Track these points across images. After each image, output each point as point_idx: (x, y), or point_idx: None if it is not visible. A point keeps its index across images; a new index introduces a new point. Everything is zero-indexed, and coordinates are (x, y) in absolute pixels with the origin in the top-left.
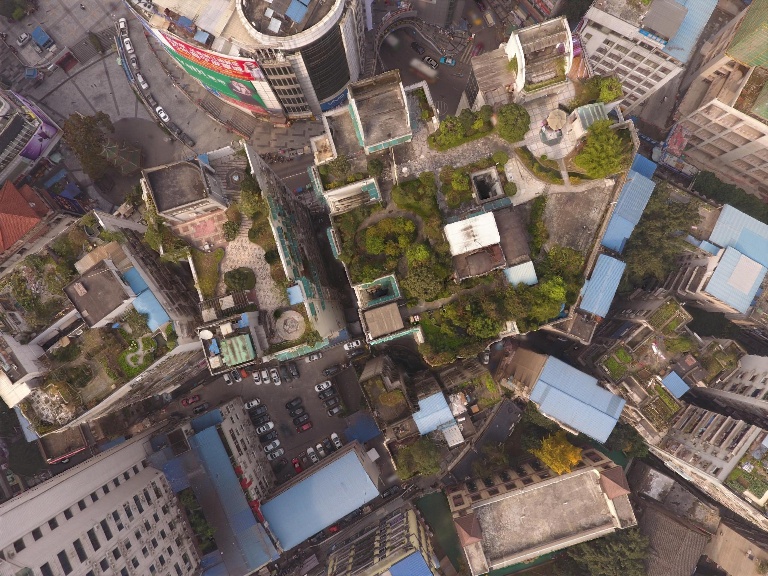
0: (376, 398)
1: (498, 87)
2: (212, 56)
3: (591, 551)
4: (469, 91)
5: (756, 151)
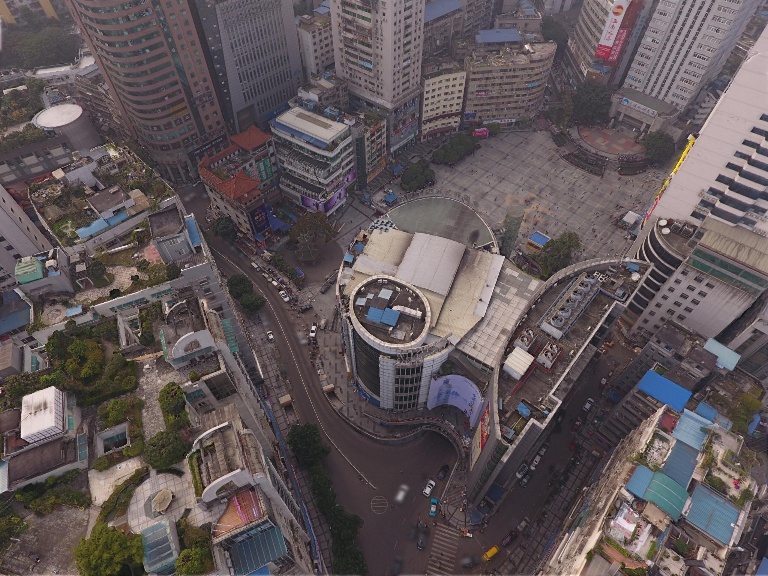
0: None
1: (203, 431)
2: None
3: None
4: None
5: None
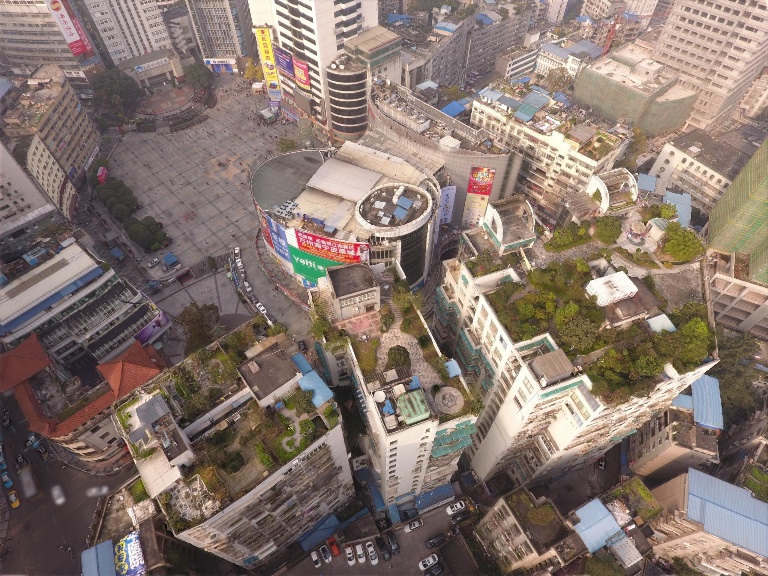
0: (525, 516)
1: (589, 210)
2: (334, 243)
3: None
4: (559, 226)
5: (767, 314)
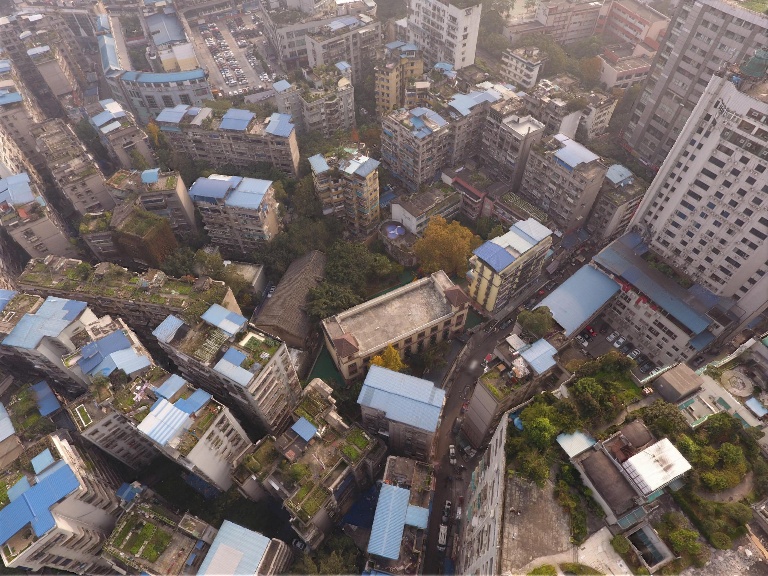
0: None
1: None
2: None
3: (352, 300)
4: None
5: None
